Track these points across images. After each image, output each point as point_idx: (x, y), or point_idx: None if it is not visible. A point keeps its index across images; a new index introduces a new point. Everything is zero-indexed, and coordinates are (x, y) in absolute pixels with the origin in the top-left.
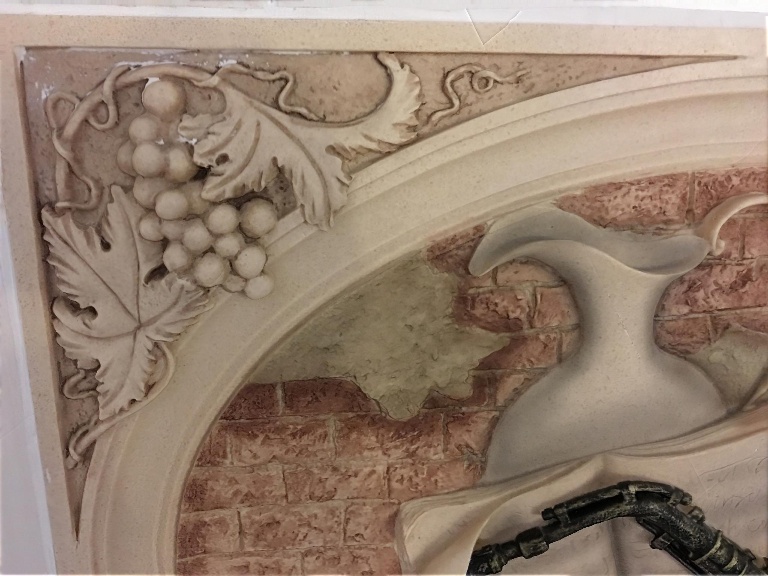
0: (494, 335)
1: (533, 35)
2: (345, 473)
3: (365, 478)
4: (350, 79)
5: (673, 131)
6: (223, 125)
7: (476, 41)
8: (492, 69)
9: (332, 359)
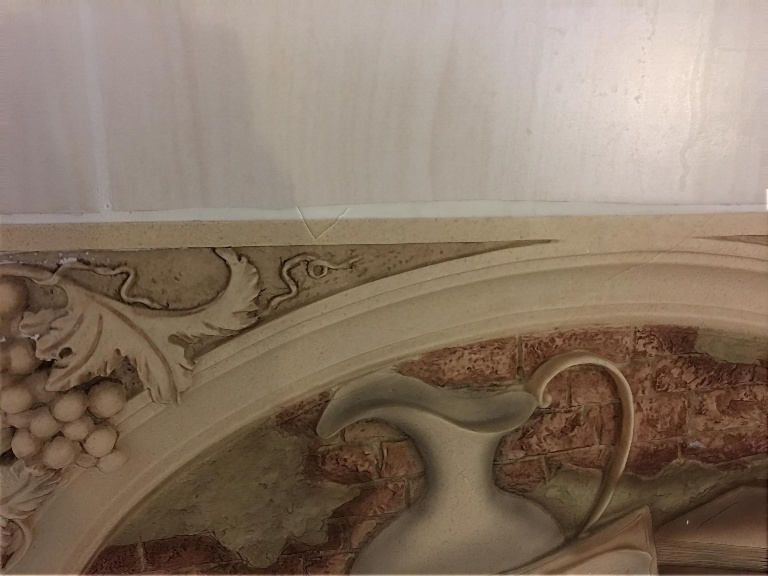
0: (345, 487)
1: (361, 229)
2: None
3: None
4: (190, 270)
5: (500, 301)
6: (65, 320)
7: (308, 236)
8: (327, 257)
9: (190, 519)
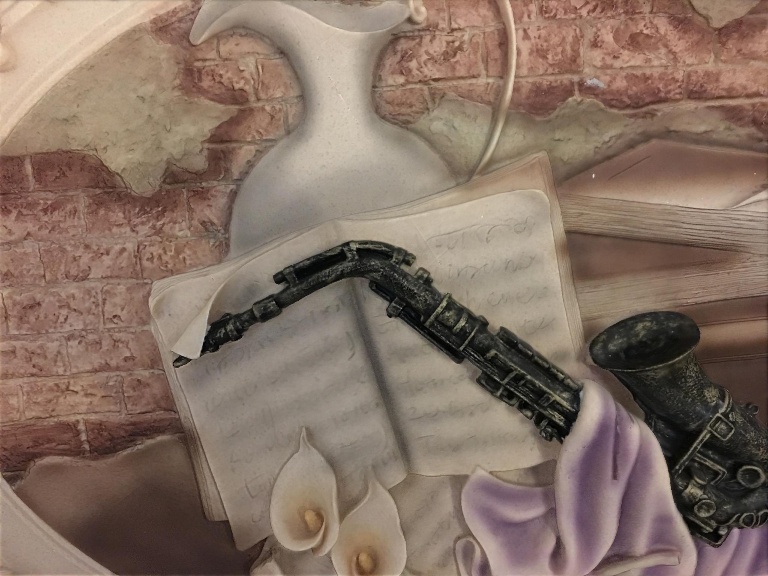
0: (222, 106)
1: None
2: (97, 251)
3: (117, 256)
4: None
5: None
6: None
7: None
8: None
9: (72, 131)
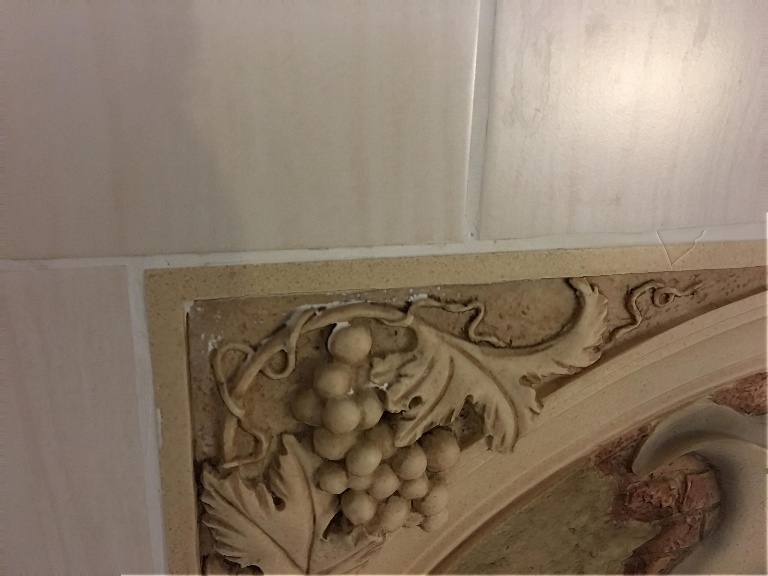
0: (648, 525)
1: (715, 253)
2: None
3: None
4: (539, 303)
5: None
6: (415, 365)
7: (665, 262)
8: (671, 283)
9: (497, 572)
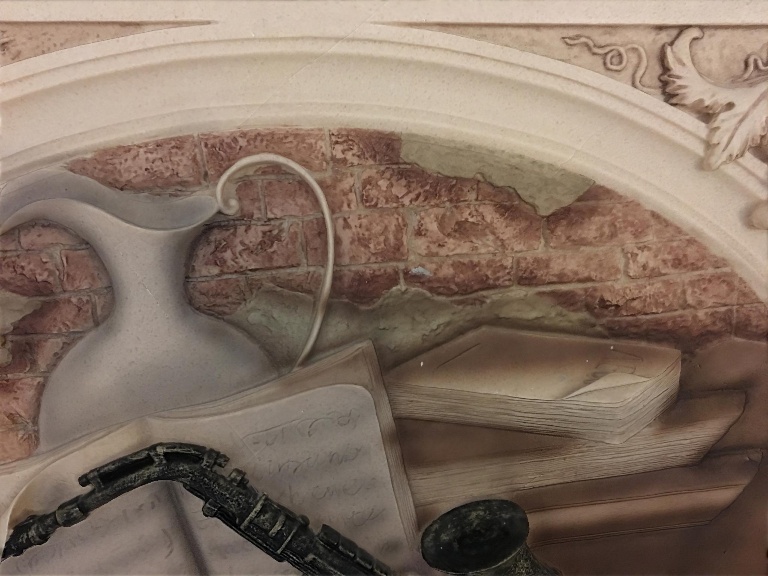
0: (24, 298)
1: (4, 4)
2: None
3: None
4: None
5: (174, 96)
6: None
7: None
8: None
9: None
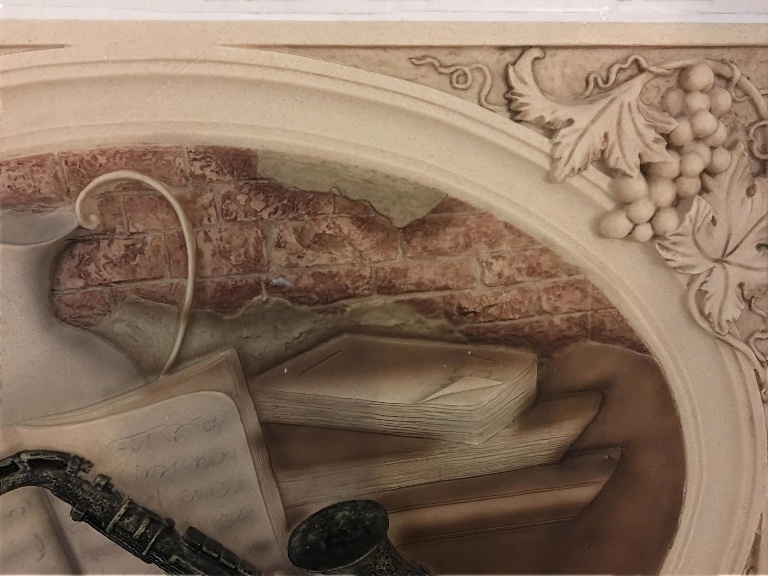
0: None
1: None
2: None
3: None
4: None
5: (34, 115)
6: None
7: None
8: None
9: None
